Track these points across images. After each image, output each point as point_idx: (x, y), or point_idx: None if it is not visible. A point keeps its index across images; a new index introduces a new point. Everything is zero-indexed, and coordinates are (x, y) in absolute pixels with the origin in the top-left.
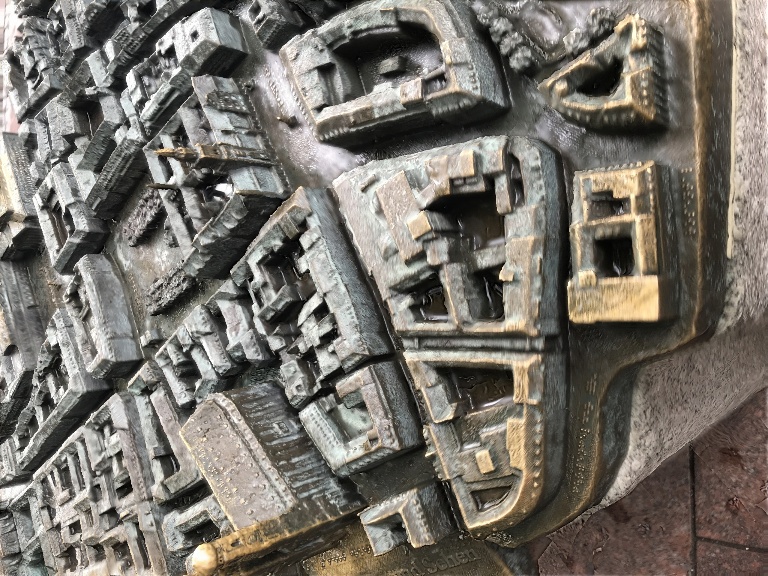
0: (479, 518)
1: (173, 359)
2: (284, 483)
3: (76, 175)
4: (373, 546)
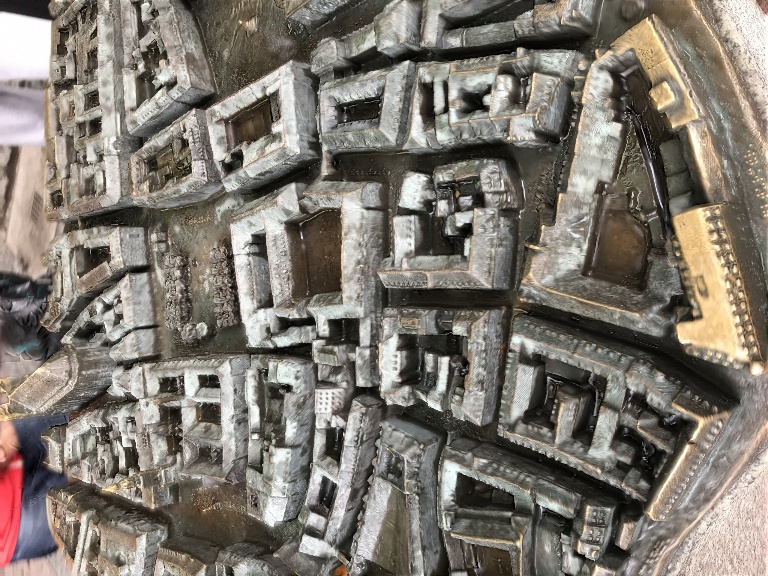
0: (50, 501)
1: (116, 309)
2: (48, 408)
3: (255, 213)
4: (44, 437)
